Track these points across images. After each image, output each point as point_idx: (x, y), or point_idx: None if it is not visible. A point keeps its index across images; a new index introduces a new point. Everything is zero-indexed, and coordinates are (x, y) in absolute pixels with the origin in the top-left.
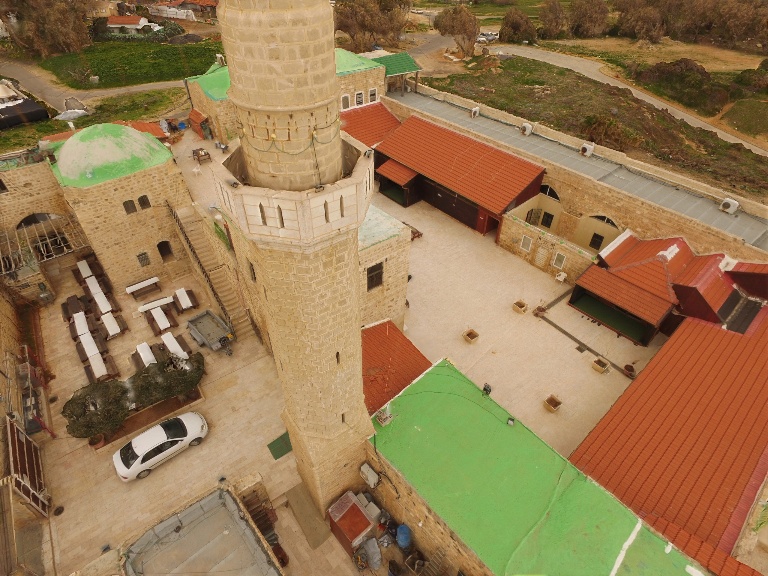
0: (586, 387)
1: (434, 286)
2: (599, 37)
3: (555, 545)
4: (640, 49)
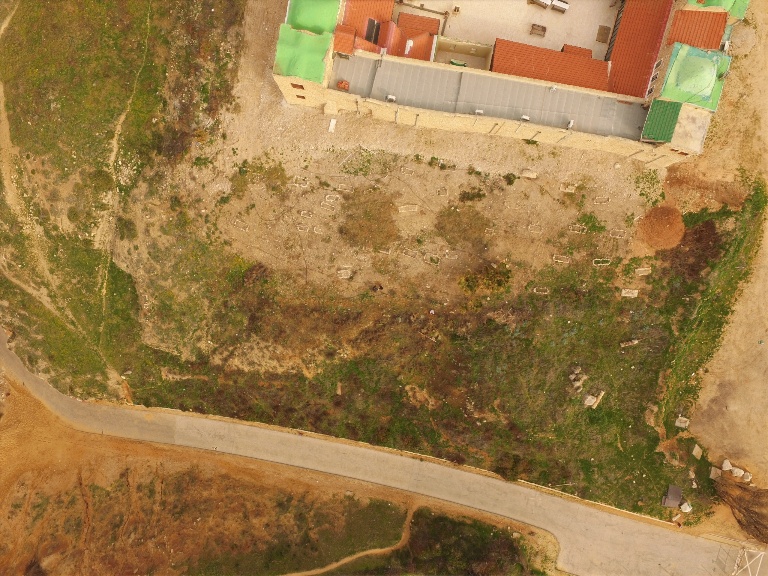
0: None
1: None
2: None
3: None
4: None
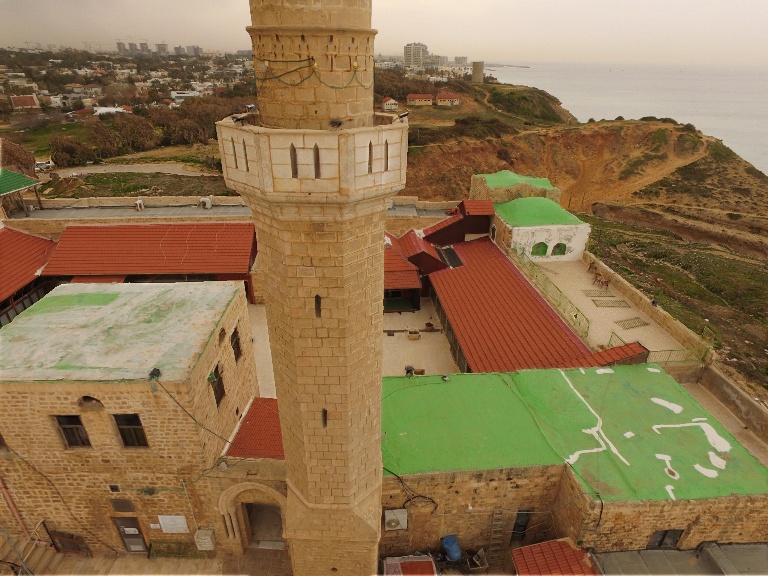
0: (421, 353)
1: None
2: (156, 148)
3: (555, 417)
4: (199, 150)
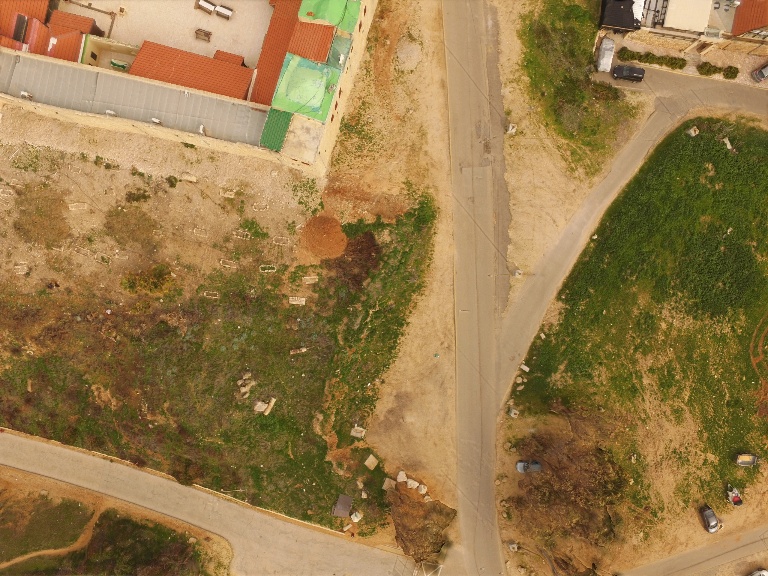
0: None
1: (167, 3)
2: None
3: None
4: None
